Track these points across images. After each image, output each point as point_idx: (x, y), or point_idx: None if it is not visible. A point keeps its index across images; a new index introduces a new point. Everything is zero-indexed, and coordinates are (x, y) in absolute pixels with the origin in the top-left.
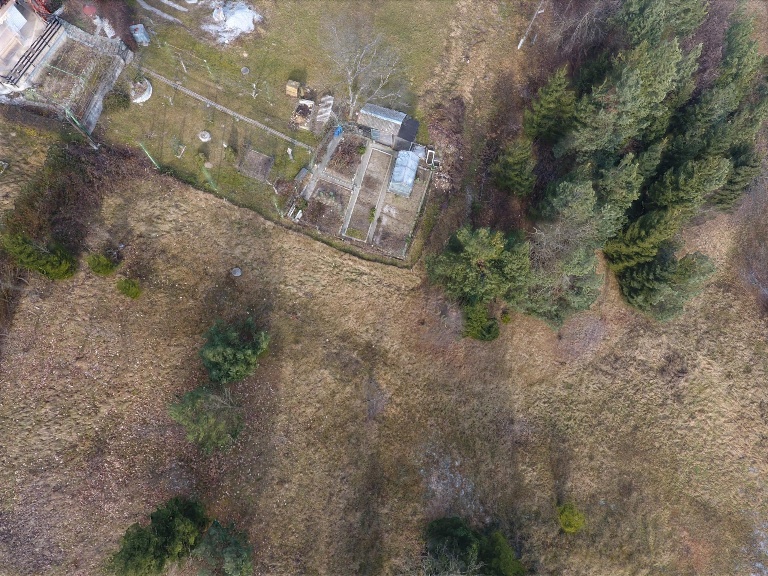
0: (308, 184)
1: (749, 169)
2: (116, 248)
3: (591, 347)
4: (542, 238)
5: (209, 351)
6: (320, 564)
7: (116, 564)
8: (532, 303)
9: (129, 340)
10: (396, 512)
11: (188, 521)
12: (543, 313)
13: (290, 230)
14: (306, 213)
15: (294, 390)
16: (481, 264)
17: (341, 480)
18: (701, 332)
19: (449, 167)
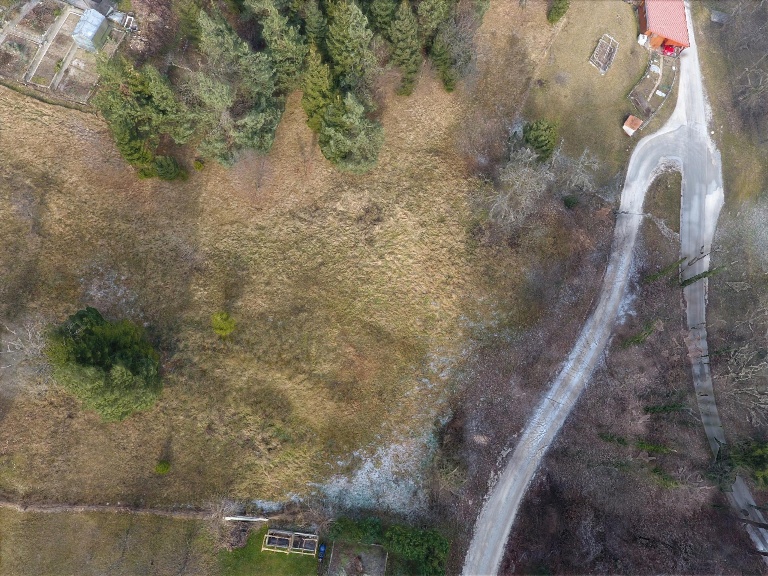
0: None
1: (401, 23)
2: None
3: (292, 198)
4: None
5: None
6: None
7: None
8: (208, 144)
9: None
10: (46, 308)
11: None
12: (222, 155)
13: None
14: None
15: None
16: (127, 94)
17: None
18: (403, 188)
19: (144, 30)
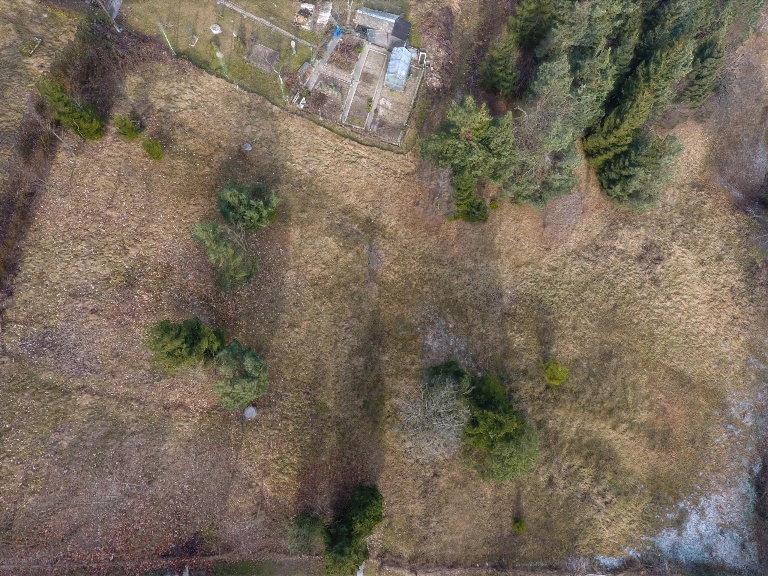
0: (310, 77)
1: (714, 61)
2: (139, 119)
3: (574, 237)
4: (525, 118)
5: (226, 193)
6: (328, 398)
7: (154, 332)
8: (517, 186)
9: (153, 196)
10: (396, 360)
11: (212, 332)
12: (528, 196)
13: (295, 115)
14: (309, 102)
15: (301, 252)
16: (469, 138)
17: (345, 330)
18: (676, 225)
19: (440, 67)
